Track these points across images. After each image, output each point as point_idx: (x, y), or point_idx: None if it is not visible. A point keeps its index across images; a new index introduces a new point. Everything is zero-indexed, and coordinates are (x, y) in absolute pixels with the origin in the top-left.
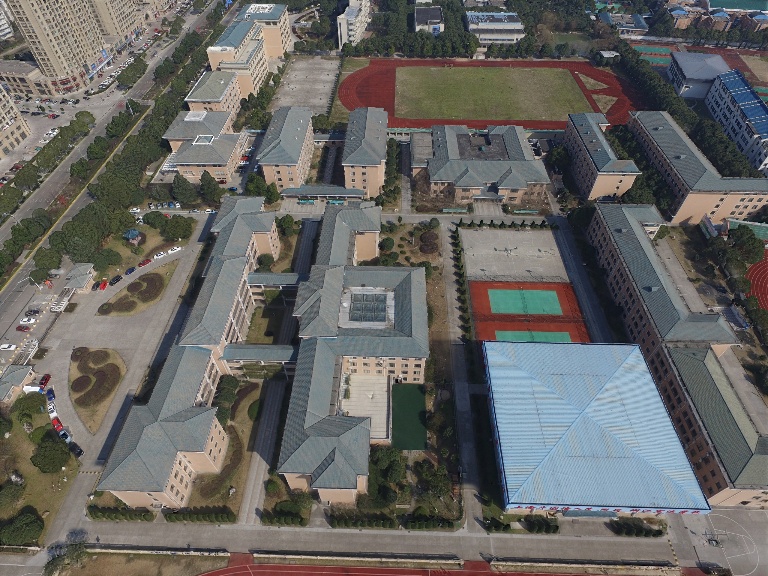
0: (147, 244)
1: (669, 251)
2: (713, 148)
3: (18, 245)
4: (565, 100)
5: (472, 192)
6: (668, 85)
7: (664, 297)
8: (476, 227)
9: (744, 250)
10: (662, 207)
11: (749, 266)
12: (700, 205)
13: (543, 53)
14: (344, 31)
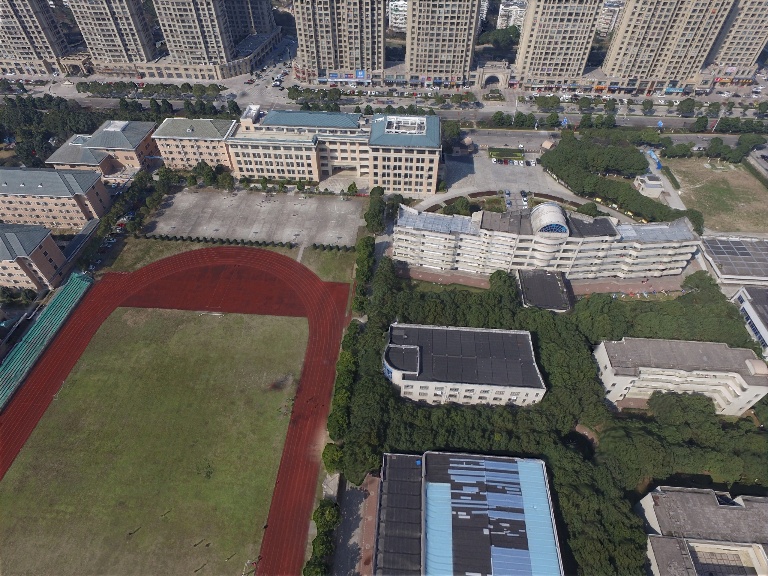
0: (4, 152)
1: None
2: None
3: (42, 104)
4: None
5: None
6: None
7: None
8: None
9: None
10: None
11: None
12: None
13: None
14: None
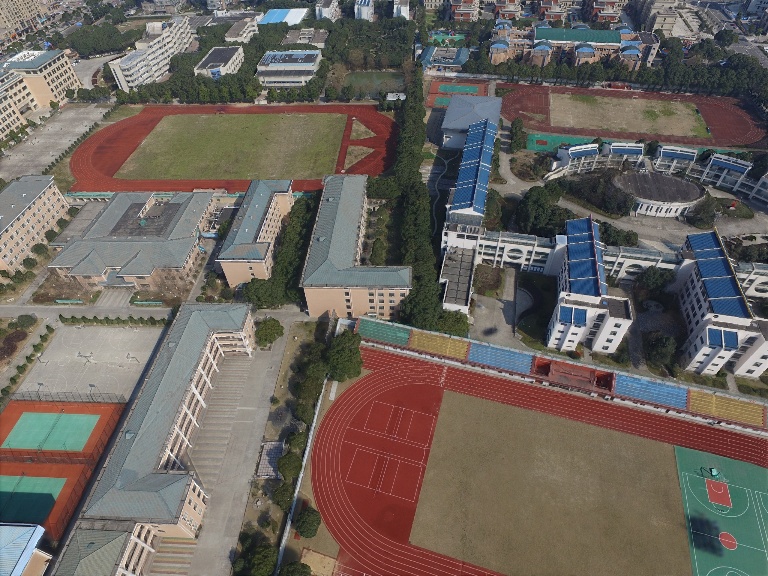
0: None
1: (278, 357)
2: (403, 220)
3: None
4: (314, 153)
5: (95, 279)
6: (413, 137)
7: (126, 450)
8: (81, 323)
9: (331, 365)
10: (293, 300)
11: (357, 380)
12: (327, 299)
13: (327, 97)
14: (121, 77)
